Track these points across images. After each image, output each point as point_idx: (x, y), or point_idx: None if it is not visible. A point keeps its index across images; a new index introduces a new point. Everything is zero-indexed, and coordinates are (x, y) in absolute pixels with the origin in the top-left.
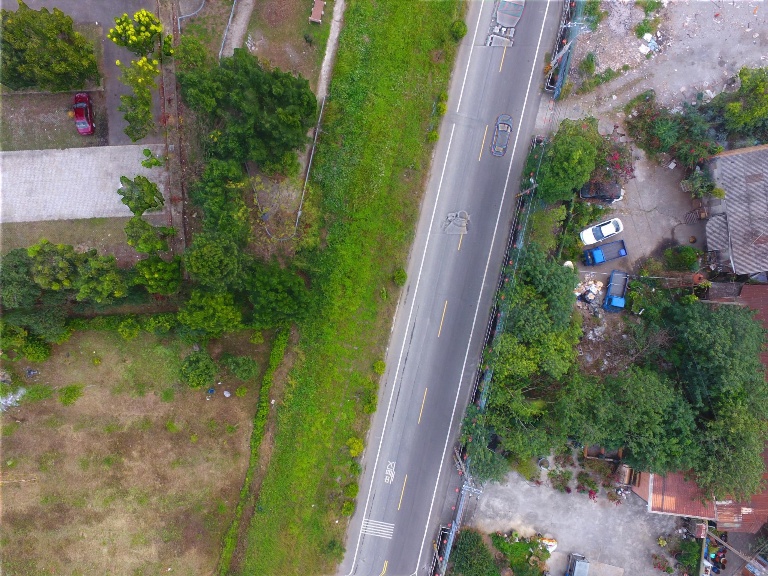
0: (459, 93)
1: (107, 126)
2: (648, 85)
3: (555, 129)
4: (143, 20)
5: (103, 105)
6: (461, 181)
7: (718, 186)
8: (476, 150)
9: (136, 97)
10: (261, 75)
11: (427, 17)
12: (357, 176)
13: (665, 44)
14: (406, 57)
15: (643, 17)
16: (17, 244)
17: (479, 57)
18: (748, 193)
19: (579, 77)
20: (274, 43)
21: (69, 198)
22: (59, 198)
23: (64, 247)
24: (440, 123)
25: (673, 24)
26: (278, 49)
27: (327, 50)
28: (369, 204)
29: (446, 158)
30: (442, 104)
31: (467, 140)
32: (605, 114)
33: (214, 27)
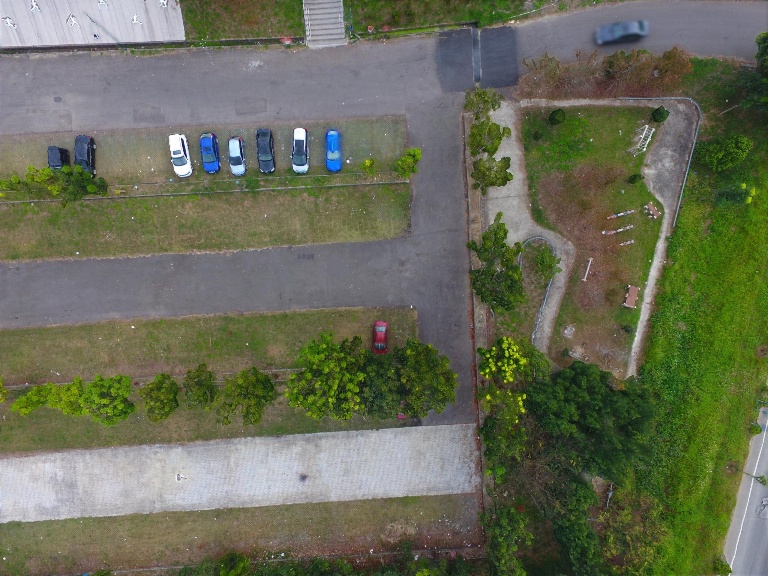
0: None
1: None
2: None
3: None
4: (514, 356)
5: None
6: None
7: None
8: None
9: (509, 434)
10: None
11: (755, 315)
12: (682, 470)
13: None
14: (733, 354)
15: None
16: (332, 523)
17: None
18: None
19: None
20: (586, 326)
21: (383, 478)
22: (373, 478)
23: (429, 573)
24: None
25: None
26: (590, 332)
27: (637, 331)
28: (694, 498)
29: (762, 444)
30: None
31: None
32: None
33: (527, 310)
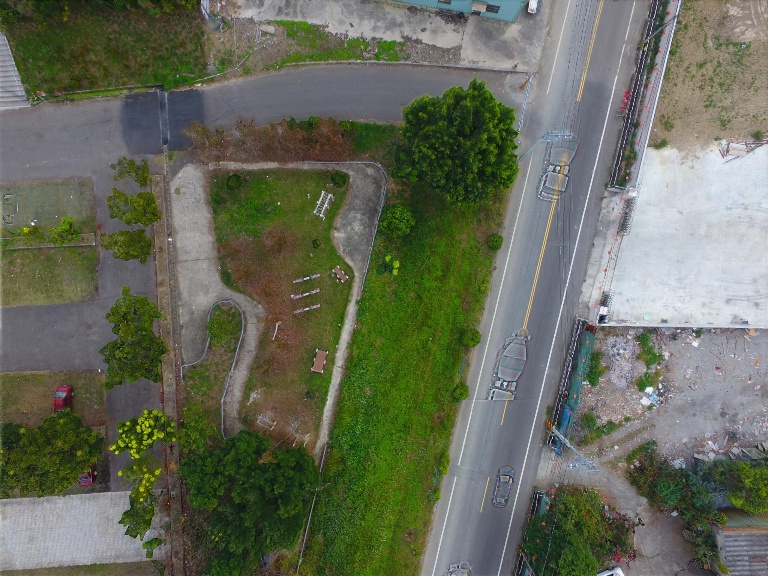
0: (461, 446)
1: (109, 472)
2: (650, 435)
3: (557, 481)
4: (145, 432)
5: (105, 451)
6: (463, 532)
7: (721, 559)
8: (478, 502)
9: (138, 512)
10: (263, 482)
11: (429, 382)
12: (358, 539)
13: (667, 395)
14: (408, 422)
15: (644, 370)
16: None
17: (481, 411)
18: (751, 573)
19: (581, 430)
20: (276, 390)
21: (70, 545)
22: (60, 545)
23: None
24: (442, 478)
25: (674, 376)
26: (280, 396)
27: (329, 395)
28: (370, 567)
29: (448, 510)
30: (444, 470)
31: (469, 492)
32: (607, 464)
33: (216, 374)
